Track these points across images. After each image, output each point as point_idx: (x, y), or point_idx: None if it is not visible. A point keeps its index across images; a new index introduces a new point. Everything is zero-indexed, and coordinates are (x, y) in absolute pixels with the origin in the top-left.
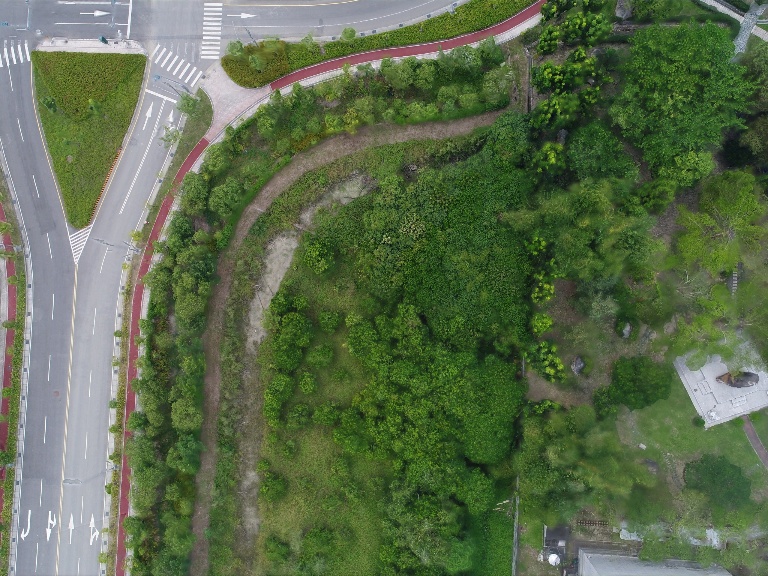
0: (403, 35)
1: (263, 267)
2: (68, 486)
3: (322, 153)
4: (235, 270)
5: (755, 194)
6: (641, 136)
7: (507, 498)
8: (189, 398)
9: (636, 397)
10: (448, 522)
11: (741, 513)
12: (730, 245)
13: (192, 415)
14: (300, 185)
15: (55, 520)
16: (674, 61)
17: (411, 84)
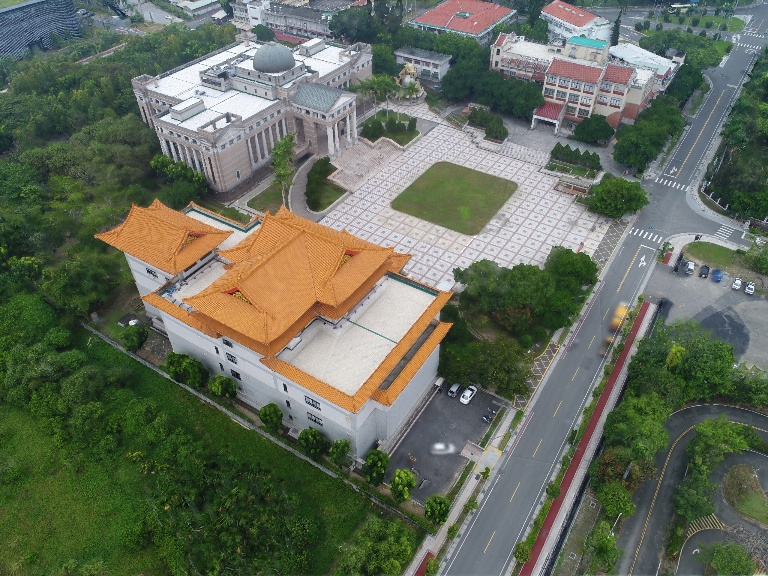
0: None
1: None
2: None
3: None
4: None
5: None
6: (1, 204)
7: (88, 337)
8: None
9: (88, 246)
10: (46, 350)
11: None
12: None
13: None
14: None
15: None
16: None
17: None
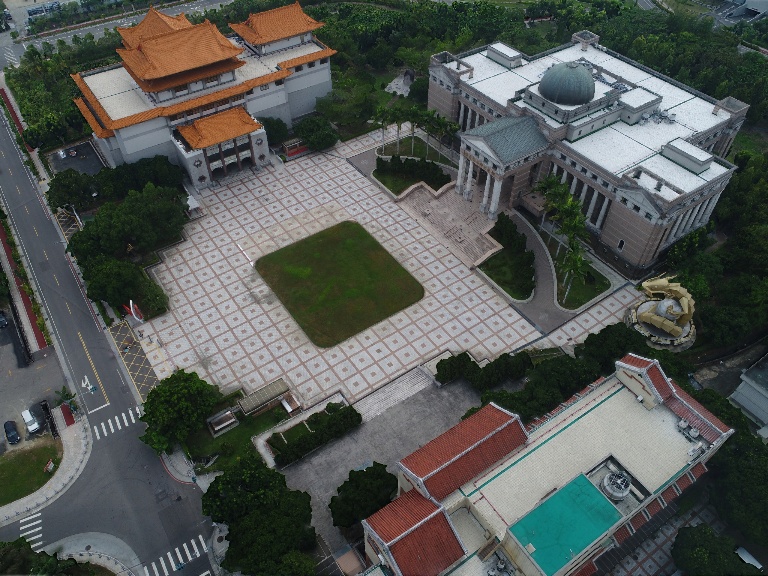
0: (436, 3)
1: (329, 11)
2: (212, 6)
3: (380, 6)
4: (321, 5)
5: (470, 36)
6: None
7: None
8: (270, 1)
9: None
10: None
11: (359, 82)
12: (449, 45)
13: (265, 2)
14: (364, 5)
15: (198, 8)
16: (486, 7)
17: (422, 4)
